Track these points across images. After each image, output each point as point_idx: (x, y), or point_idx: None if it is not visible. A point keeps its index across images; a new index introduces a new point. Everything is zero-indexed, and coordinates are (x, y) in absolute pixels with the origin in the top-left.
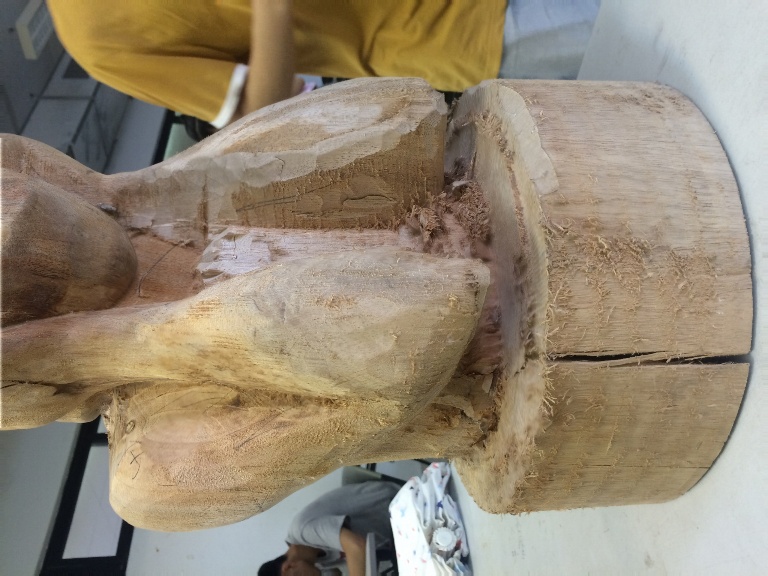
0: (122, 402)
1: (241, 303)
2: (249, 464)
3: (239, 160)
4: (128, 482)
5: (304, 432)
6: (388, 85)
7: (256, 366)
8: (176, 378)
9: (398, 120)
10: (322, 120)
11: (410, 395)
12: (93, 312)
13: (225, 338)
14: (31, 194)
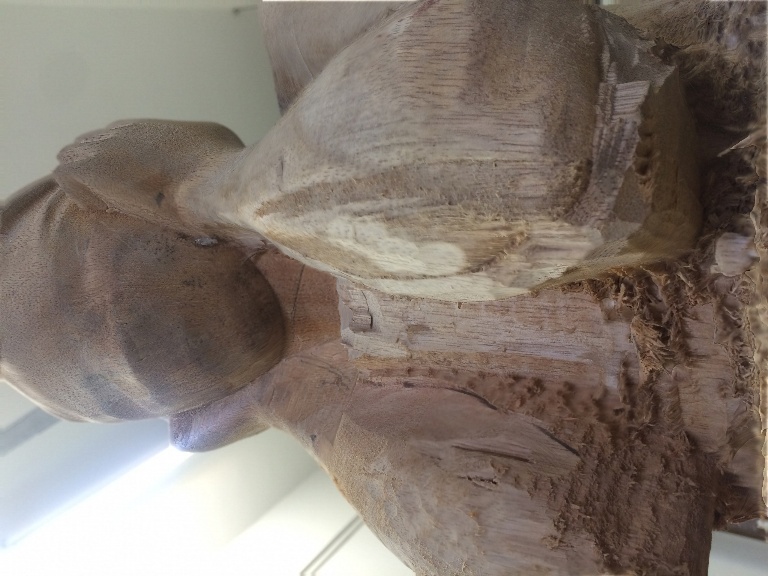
0: None
1: None
2: None
3: None
4: None
5: None
6: (461, 186)
7: None
8: None
9: (510, 267)
10: (363, 251)
11: None
12: (267, 376)
13: None
14: (126, 348)
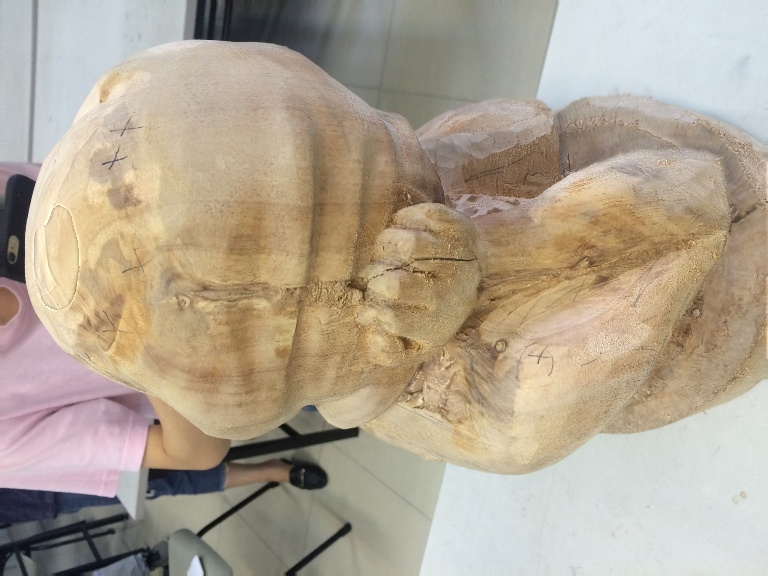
0: (466, 338)
1: (610, 173)
2: (647, 317)
3: (462, 138)
4: (544, 381)
5: (677, 274)
6: None
7: (639, 218)
8: (557, 264)
9: (544, 117)
10: (505, 112)
11: (729, 225)
12: None
13: (613, 198)
14: None
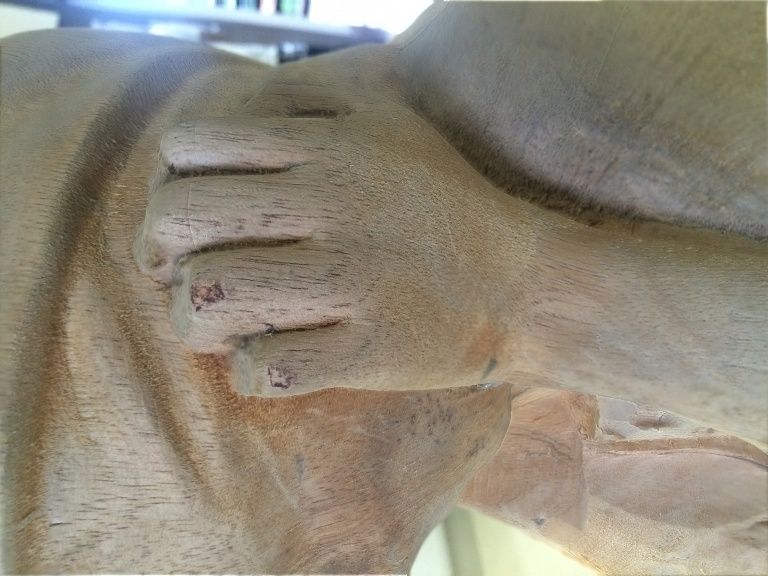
0: None
1: None
2: None
3: None
4: None
5: None
6: None
7: None
8: None
9: None
10: None
11: None
12: None
13: None
14: None
